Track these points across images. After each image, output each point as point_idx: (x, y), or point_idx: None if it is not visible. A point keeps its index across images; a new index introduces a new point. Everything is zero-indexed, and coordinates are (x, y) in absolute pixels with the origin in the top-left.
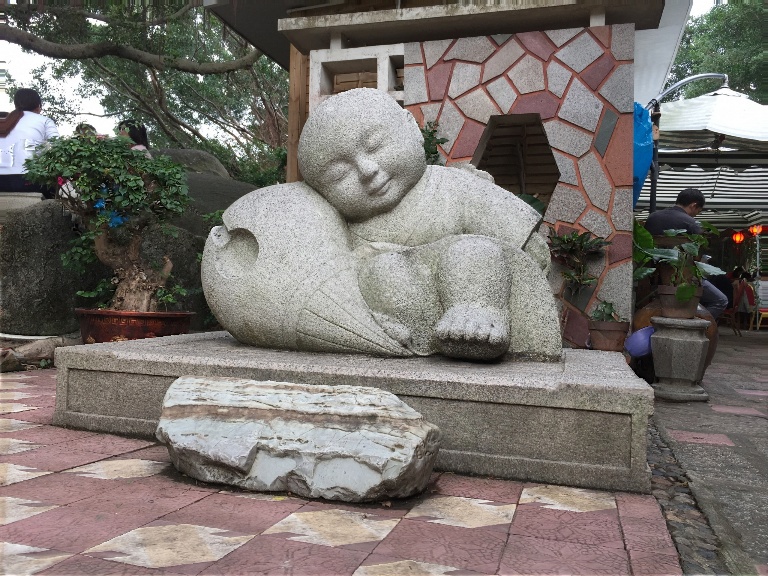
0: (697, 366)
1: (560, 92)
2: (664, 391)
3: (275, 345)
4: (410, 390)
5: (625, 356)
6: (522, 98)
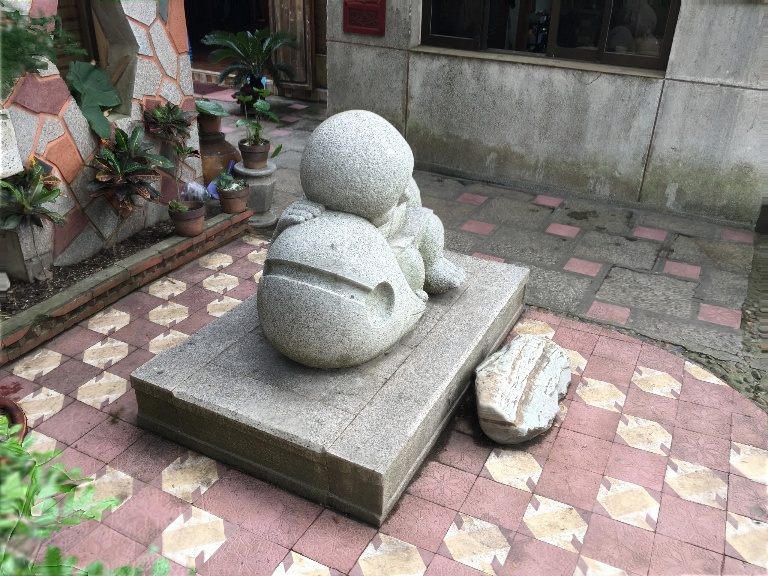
0: None
1: None
2: (263, 223)
3: None
4: None
5: (252, 210)
6: None
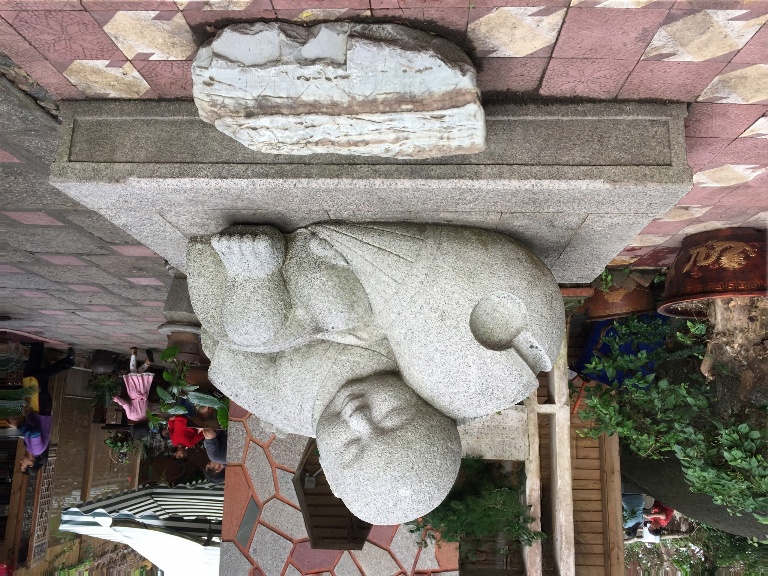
0: (170, 291)
1: (290, 570)
2: None
3: (454, 228)
4: (263, 169)
5: None
6: (329, 567)
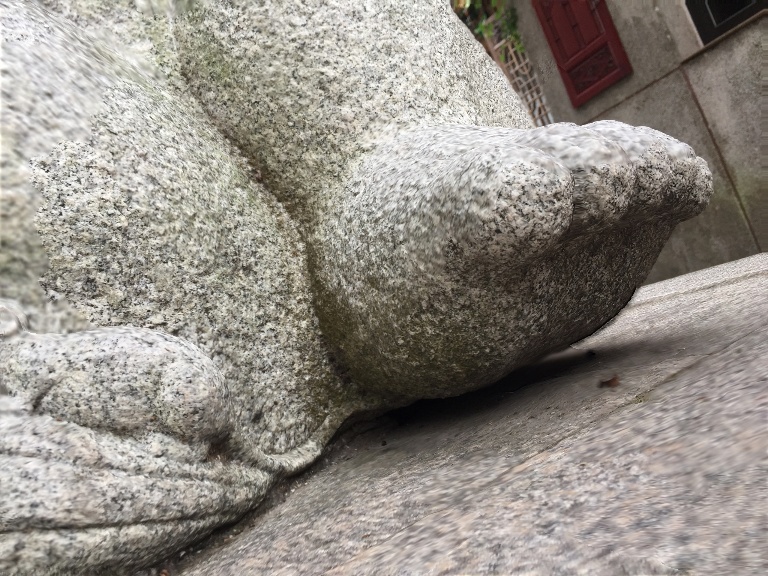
0: None
1: None
2: None
3: None
4: None
5: None
6: None
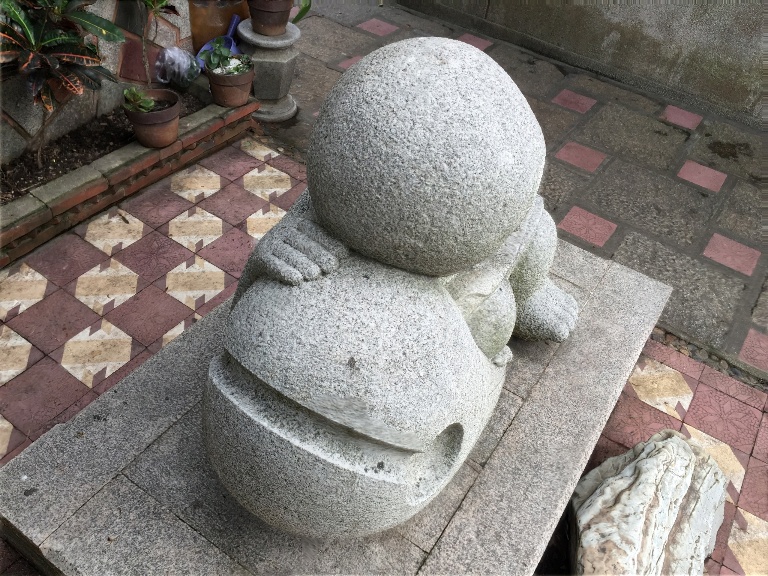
0: None
1: None
2: (275, 115)
3: None
4: None
5: (257, 102)
6: None
